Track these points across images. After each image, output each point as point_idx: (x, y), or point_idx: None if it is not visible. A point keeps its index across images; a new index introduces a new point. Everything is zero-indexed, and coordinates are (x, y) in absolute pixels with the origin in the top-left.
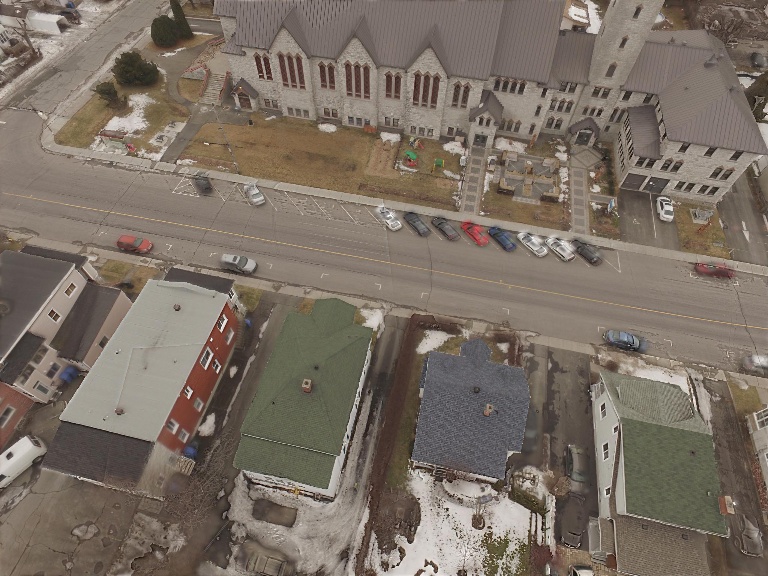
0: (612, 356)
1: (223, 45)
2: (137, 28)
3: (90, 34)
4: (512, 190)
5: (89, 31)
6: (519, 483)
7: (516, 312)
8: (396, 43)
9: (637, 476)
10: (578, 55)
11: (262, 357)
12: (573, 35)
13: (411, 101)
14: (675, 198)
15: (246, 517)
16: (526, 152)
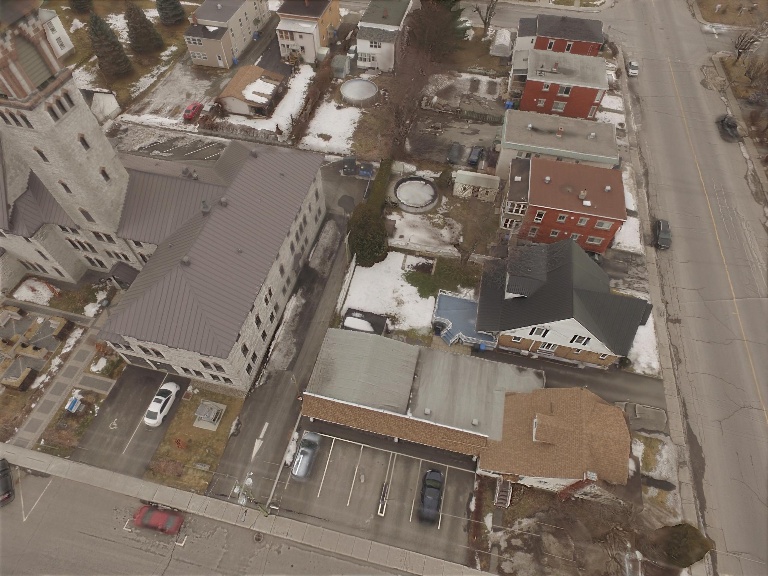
0: None
1: None
2: None
3: None
4: None
5: None
6: None
7: None
8: None
9: None
10: None
11: None
12: None
13: None
14: (196, 382)
15: None
16: (48, 303)
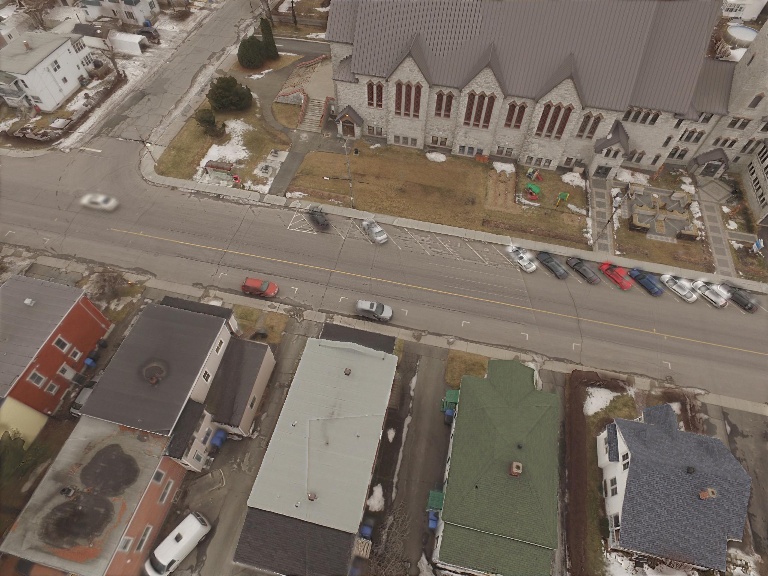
0: None
1: (315, 67)
2: (218, 48)
3: (171, 54)
4: (647, 227)
5: (170, 51)
6: (730, 571)
7: (678, 366)
8: (526, 72)
9: None
10: (716, 84)
11: (419, 418)
12: (710, 62)
13: (534, 131)
14: None
15: None
16: (650, 184)
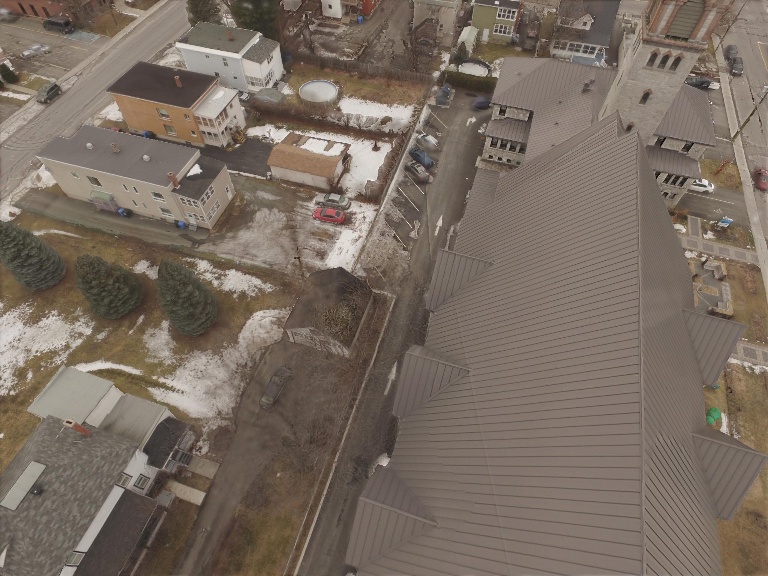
0: None
1: None
2: None
3: None
4: None
5: None
6: None
7: None
8: (696, 386)
9: None
10: None
11: None
12: None
13: None
14: None
15: None
16: None
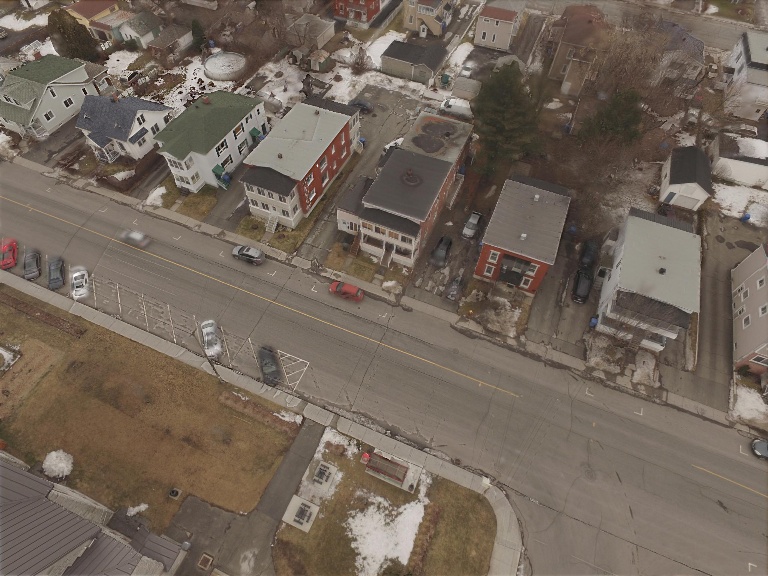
0: (7, 152)
1: None
2: None
3: None
4: None
5: None
6: None
7: (43, 188)
8: None
9: (65, 70)
10: None
11: None
12: None
13: None
14: None
15: (274, 119)
16: None
